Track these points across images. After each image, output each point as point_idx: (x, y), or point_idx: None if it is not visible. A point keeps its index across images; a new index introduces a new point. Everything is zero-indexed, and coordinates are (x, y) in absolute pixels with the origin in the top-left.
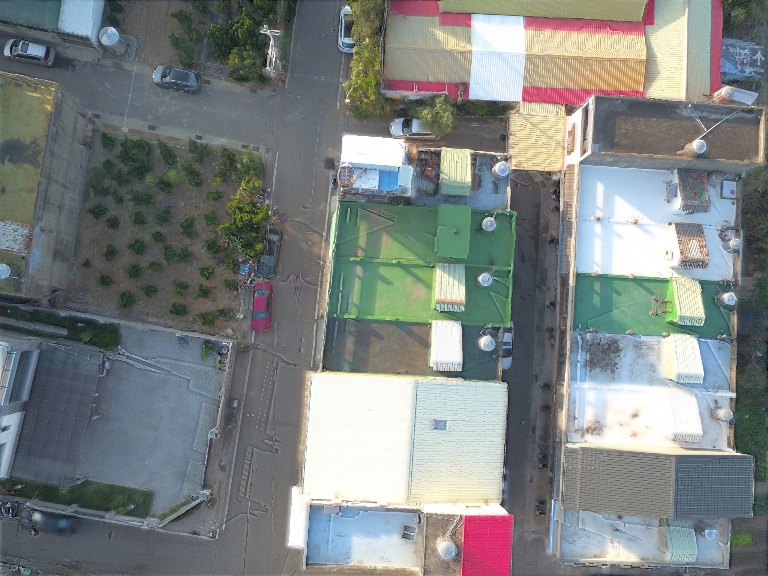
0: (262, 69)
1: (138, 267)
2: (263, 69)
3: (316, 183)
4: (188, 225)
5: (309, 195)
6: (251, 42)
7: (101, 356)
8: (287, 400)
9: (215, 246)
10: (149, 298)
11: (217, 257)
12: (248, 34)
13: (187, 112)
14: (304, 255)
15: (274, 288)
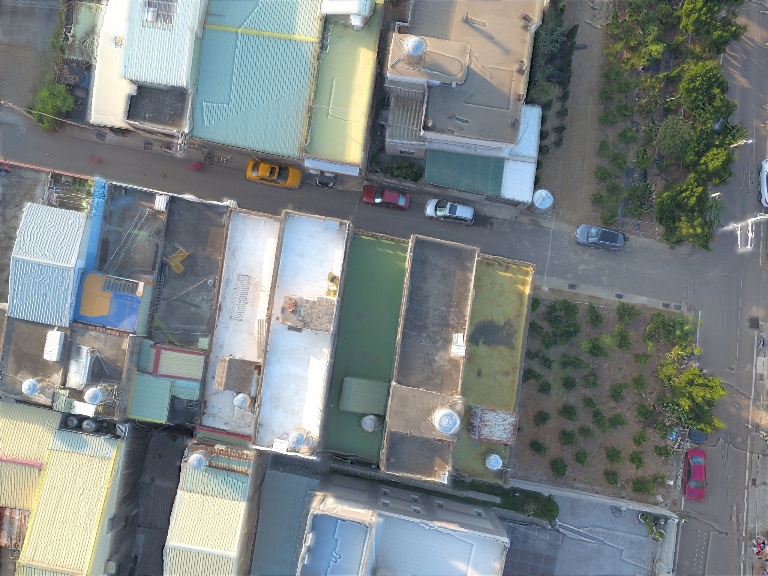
0: (707, 235)
1: (572, 434)
2: (708, 234)
3: (740, 343)
4: (621, 391)
5: (734, 356)
6: (698, 208)
7: (560, 536)
8: (721, 571)
9: (648, 412)
10: (576, 463)
11: (642, 420)
12: (696, 200)
13: (607, 270)
14: (731, 418)
15: (706, 454)
